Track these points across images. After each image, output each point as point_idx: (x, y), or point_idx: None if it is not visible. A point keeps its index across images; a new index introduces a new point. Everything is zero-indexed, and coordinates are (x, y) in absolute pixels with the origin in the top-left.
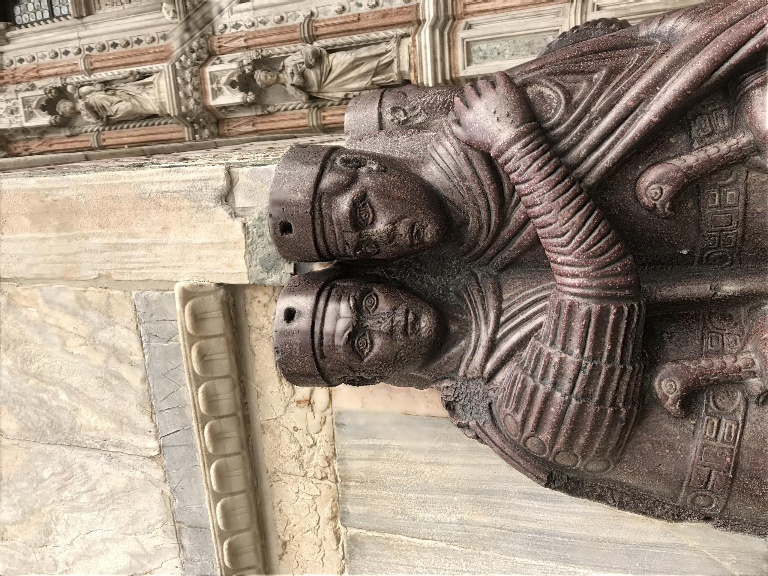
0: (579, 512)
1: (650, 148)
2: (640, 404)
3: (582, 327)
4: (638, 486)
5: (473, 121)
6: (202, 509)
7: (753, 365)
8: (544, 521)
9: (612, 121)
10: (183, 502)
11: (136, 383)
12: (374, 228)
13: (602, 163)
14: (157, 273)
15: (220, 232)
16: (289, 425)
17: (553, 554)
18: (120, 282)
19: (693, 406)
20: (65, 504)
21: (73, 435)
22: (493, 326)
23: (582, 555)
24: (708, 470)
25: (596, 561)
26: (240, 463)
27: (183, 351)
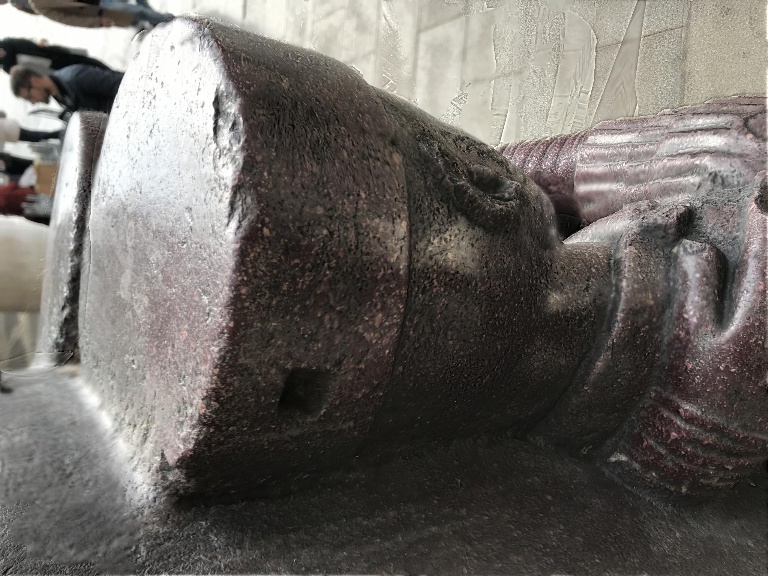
0: None
1: None
2: None
3: None
4: None
5: None
6: None
7: None
8: None
9: None
10: None
11: None
12: None
13: None
14: None
15: None
16: None
17: None
18: None
19: None
20: None
21: None
22: None
23: None
24: None
25: None
26: None
27: None
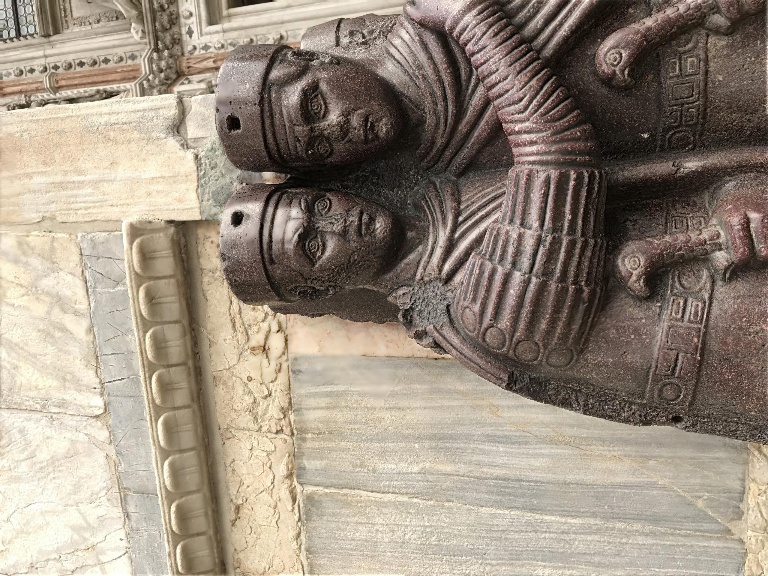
0: (545, 452)
1: (609, 20)
2: (603, 286)
3: (541, 196)
4: (603, 382)
5: None
6: (149, 472)
7: (718, 236)
8: (509, 465)
9: None
10: (129, 465)
11: (80, 335)
12: (326, 121)
13: (560, 32)
14: (104, 213)
15: (171, 165)
16: (242, 375)
17: (519, 501)
18: (65, 224)
19: (658, 288)
20: (2, 475)
21: (12, 396)
22: (451, 225)
23: (549, 500)
24: (675, 353)
25: (563, 506)
26: (190, 417)
27: (130, 293)
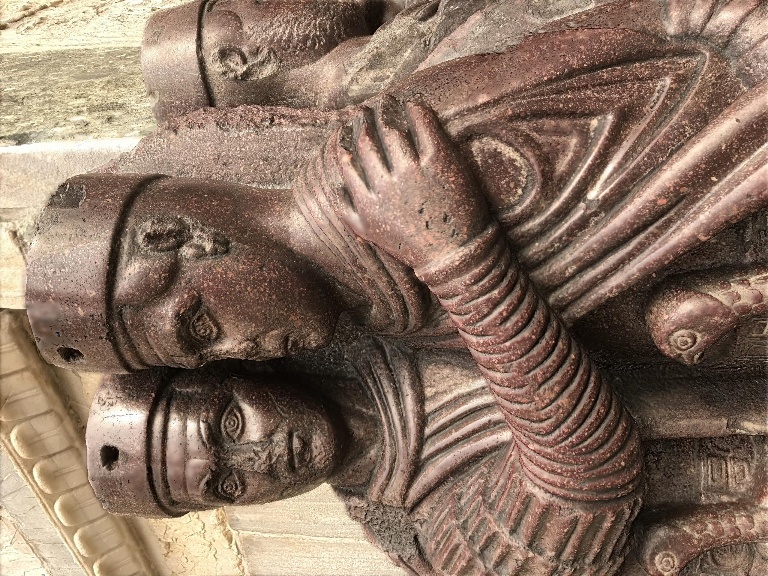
0: None
1: None
2: (622, 570)
3: (563, 534)
4: None
5: (380, 219)
6: None
7: None
8: None
9: (627, 229)
10: (31, 524)
11: None
12: (222, 346)
13: (602, 290)
14: None
15: None
16: None
17: None
18: None
19: None
20: None
21: None
22: (415, 444)
23: None
24: None
25: None
26: (92, 492)
27: None
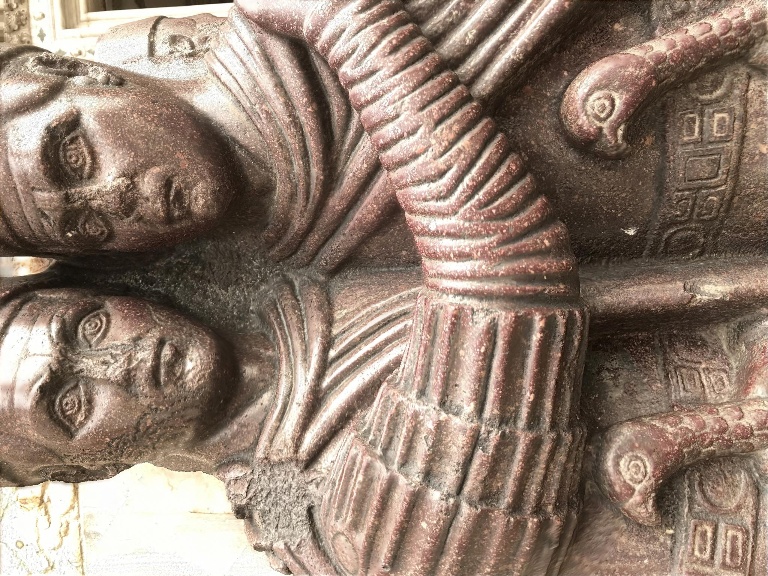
0: None
1: (582, 40)
2: (580, 503)
3: (480, 358)
4: None
5: None
6: None
7: None
8: None
9: None
10: None
11: None
12: (94, 184)
13: (505, 54)
14: None
15: None
16: (9, 539)
17: None
18: None
19: (667, 501)
20: None
21: None
22: (316, 366)
23: None
24: None
25: None
26: None
27: None
